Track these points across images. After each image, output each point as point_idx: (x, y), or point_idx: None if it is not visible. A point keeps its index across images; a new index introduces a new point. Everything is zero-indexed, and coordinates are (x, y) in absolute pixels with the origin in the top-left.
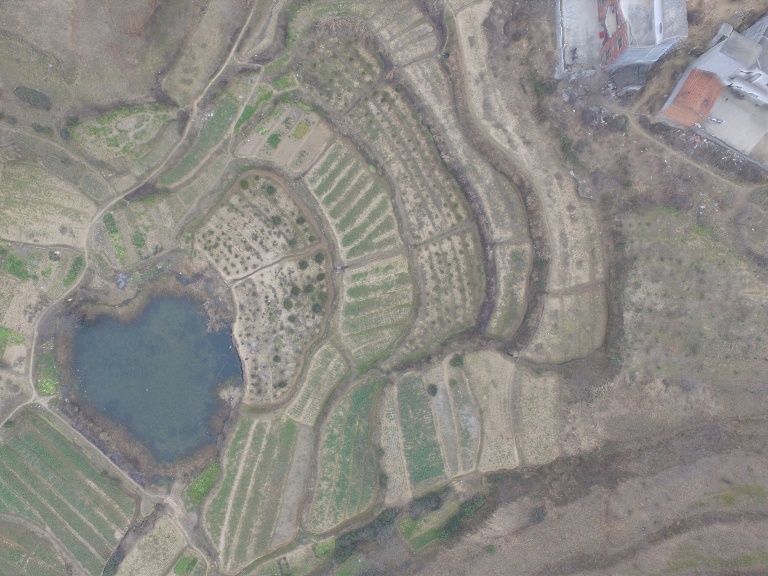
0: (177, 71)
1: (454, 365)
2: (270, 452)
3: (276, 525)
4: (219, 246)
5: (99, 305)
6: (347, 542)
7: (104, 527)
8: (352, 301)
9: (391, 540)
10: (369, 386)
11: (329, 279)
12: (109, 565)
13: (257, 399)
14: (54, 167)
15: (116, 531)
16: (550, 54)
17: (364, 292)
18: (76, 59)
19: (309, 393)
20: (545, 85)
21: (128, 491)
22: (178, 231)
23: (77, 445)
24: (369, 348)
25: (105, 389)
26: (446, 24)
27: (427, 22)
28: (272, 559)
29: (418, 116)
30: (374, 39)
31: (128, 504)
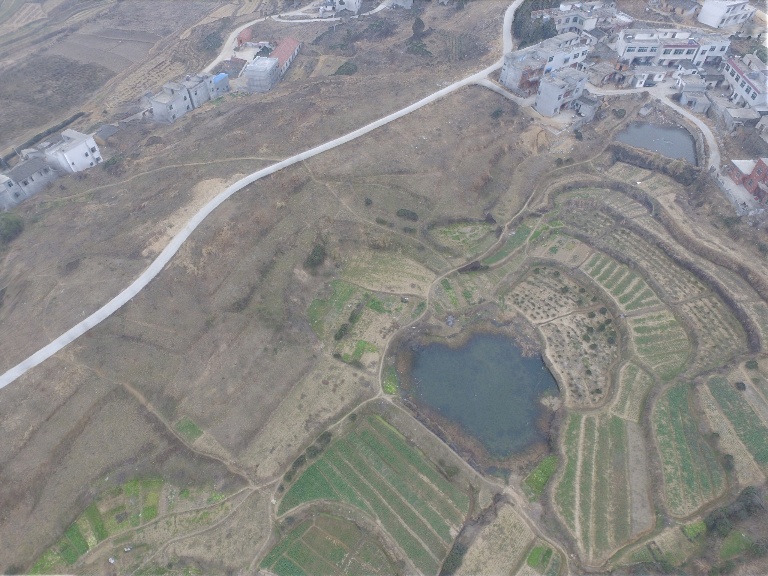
0: (495, 210)
1: (752, 366)
2: (605, 442)
3: (631, 511)
4: (524, 302)
5: (432, 336)
6: (722, 513)
7: (438, 522)
8: (639, 335)
9: (767, 513)
10: (680, 388)
11: (613, 325)
12: (454, 553)
13: (578, 402)
14: (410, 253)
15: (450, 527)
16: (728, 206)
17: (647, 330)
18: (437, 200)
19: (626, 396)
20: (733, 219)
21: (460, 487)
22: (495, 291)
23: (410, 441)
24: (666, 366)
25: (436, 396)
26: (651, 202)
27: (637, 202)
28: (640, 544)
29: (648, 241)
30: (607, 207)
31: (463, 498)
